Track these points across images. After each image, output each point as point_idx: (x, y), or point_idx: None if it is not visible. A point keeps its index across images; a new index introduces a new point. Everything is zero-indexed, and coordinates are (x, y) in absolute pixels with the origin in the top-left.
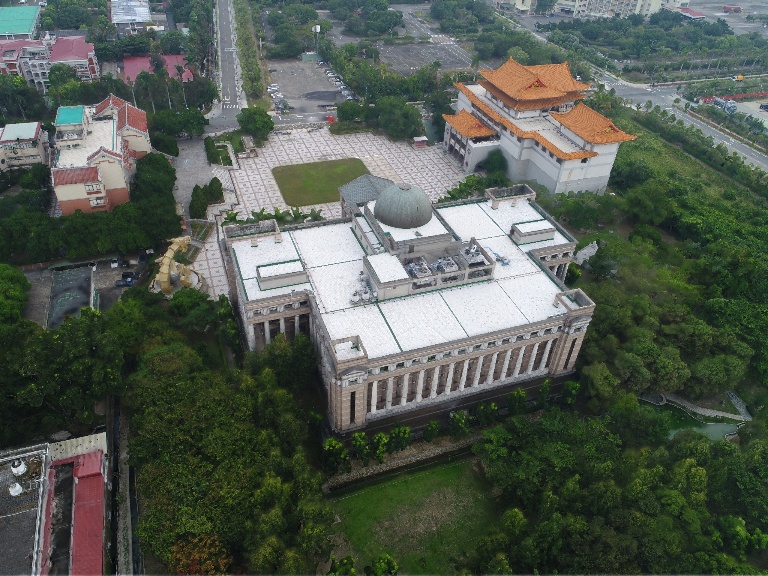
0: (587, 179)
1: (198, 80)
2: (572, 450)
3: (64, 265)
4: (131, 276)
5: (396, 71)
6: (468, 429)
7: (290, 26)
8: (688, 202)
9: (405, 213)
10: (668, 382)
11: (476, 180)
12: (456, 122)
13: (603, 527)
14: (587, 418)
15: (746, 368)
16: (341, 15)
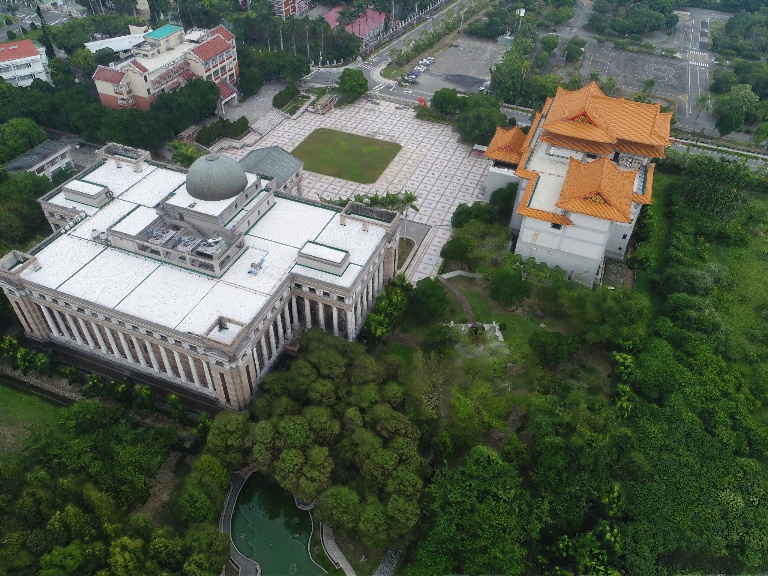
0: (563, 252)
1: (341, 34)
2: (103, 461)
3: (79, 141)
4: None
5: (582, 77)
6: (91, 392)
7: (535, 8)
8: (689, 342)
9: (193, 181)
10: (281, 480)
11: (411, 198)
12: (499, 138)
13: None
14: (138, 444)
15: (409, 539)
16: (599, 7)
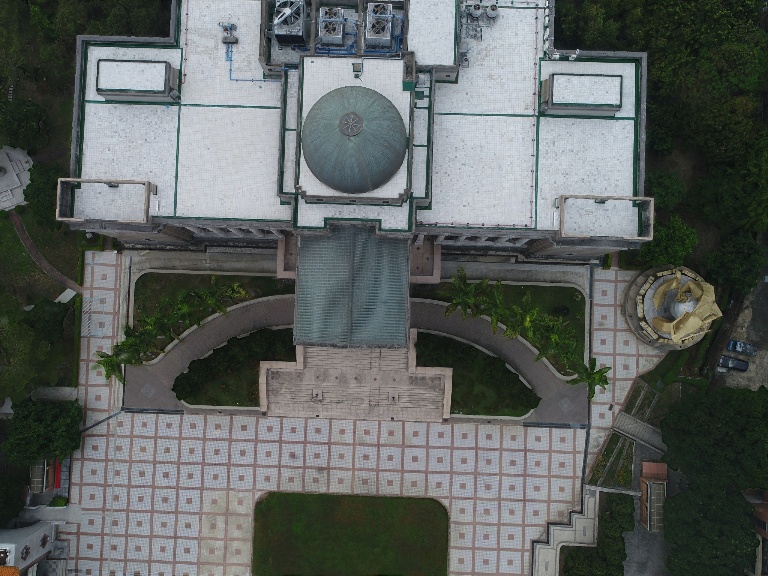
0: None
1: None
2: None
3: None
4: (735, 359)
5: None
6: None
7: None
8: None
9: (370, 90)
10: None
11: None
12: None
13: None
14: None
15: None
16: None
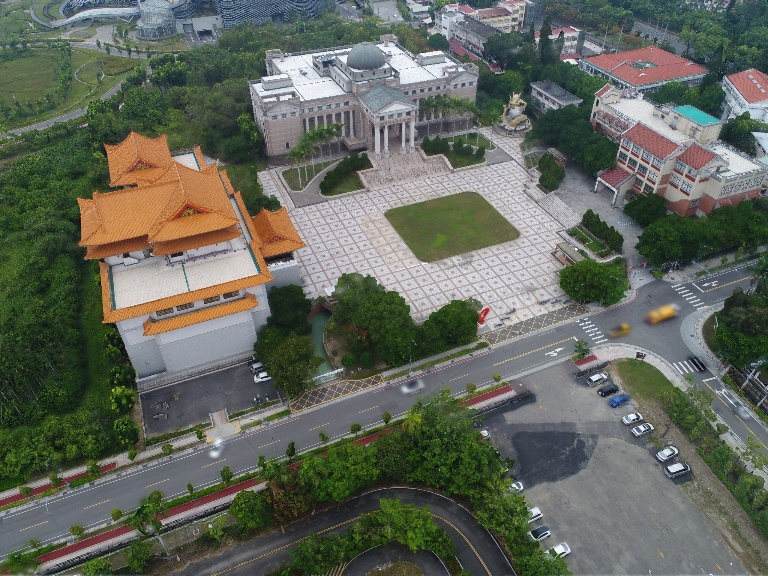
0: None
1: None
2: None
3: None
4: None
5: None
6: None
7: None
8: None
9: None
10: None
11: (294, 149)
12: (289, 230)
13: (294, 50)
14: None
15: None
16: None
